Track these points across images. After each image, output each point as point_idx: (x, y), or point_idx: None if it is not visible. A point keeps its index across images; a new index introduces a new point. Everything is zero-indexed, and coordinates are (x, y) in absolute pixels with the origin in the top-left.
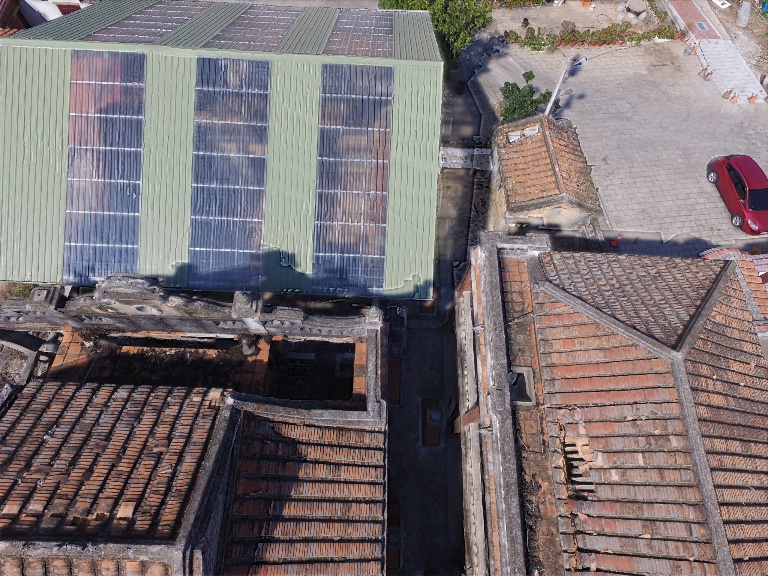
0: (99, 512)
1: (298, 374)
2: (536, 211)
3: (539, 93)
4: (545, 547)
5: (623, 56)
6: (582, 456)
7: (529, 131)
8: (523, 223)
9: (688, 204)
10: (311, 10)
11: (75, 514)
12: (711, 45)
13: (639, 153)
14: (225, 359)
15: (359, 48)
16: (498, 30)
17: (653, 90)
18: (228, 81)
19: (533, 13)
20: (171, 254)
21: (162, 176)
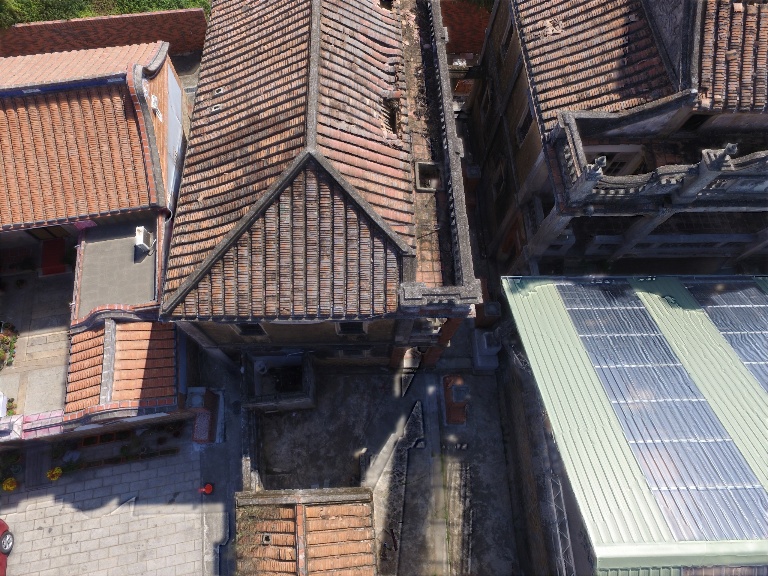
0: (754, 6)
1: None
2: None
3: None
4: (413, 84)
5: None
6: None
7: None
8: None
9: None
10: None
11: (767, 5)
12: None
13: None
14: None
15: None
16: None
17: None
18: None
19: None
20: None
21: None
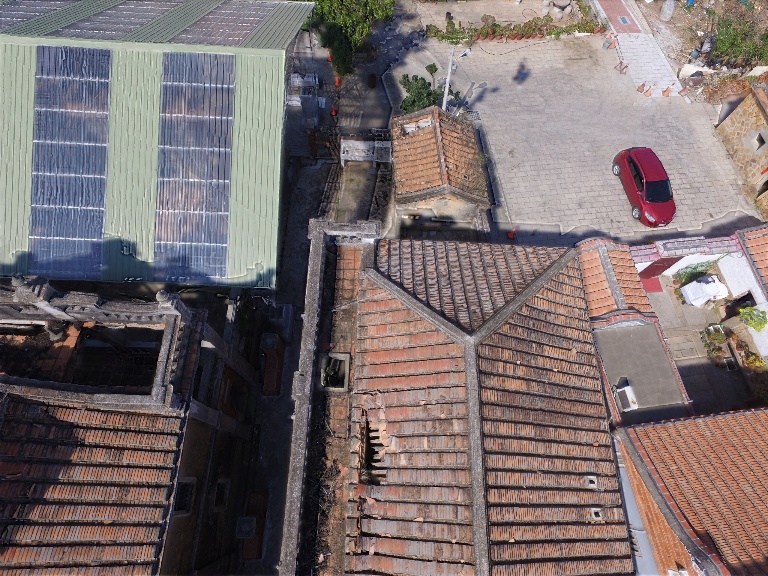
0: None
1: (146, 363)
2: (423, 202)
3: (452, 86)
4: (335, 532)
5: (541, 50)
6: (381, 441)
7: (423, 123)
8: (415, 215)
9: (590, 196)
10: (194, 1)
11: None
12: (631, 39)
13: (547, 146)
14: (31, 345)
15: (209, 37)
16: (421, 24)
17: (568, 83)
18: (68, 69)
19: (458, 7)
20: (11, 242)
21: (2, 164)
